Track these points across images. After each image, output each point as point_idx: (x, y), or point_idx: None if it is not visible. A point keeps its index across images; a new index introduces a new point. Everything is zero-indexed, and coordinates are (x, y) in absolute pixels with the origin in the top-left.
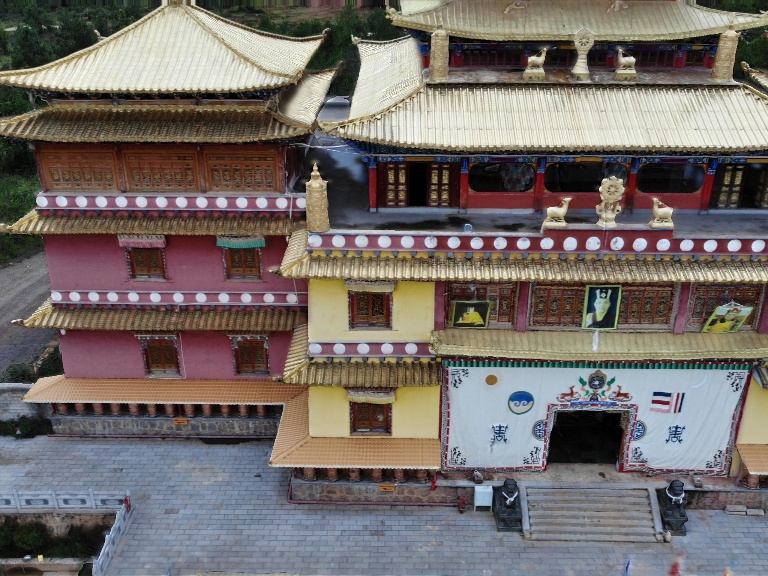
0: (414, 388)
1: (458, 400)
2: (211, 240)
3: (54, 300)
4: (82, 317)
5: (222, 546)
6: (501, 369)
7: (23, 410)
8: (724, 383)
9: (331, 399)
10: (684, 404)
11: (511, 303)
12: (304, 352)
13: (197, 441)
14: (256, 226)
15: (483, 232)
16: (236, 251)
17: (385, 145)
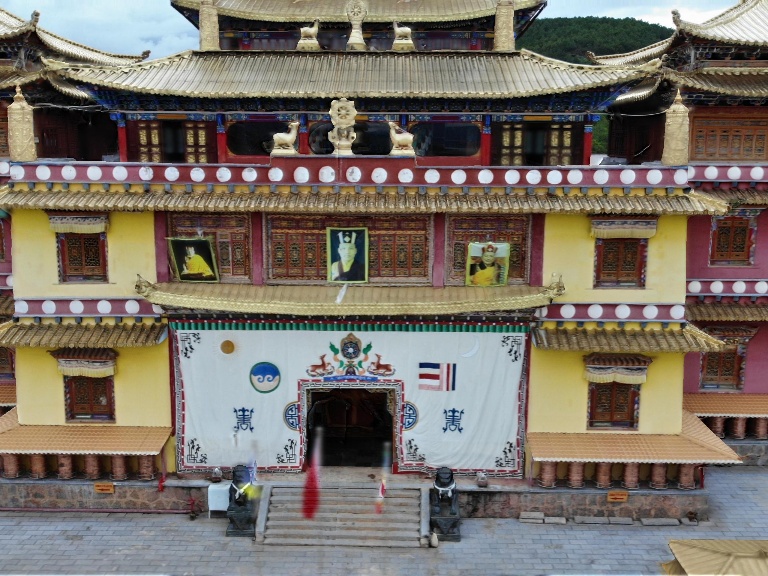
0: (138, 358)
1: (191, 374)
2: None
3: None
4: None
5: None
6: (237, 333)
7: None
8: (500, 350)
9: (42, 374)
10: (457, 379)
11: (246, 251)
12: None
13: None
14: None
15: (205, 163)
16: None
17: (130, 98)
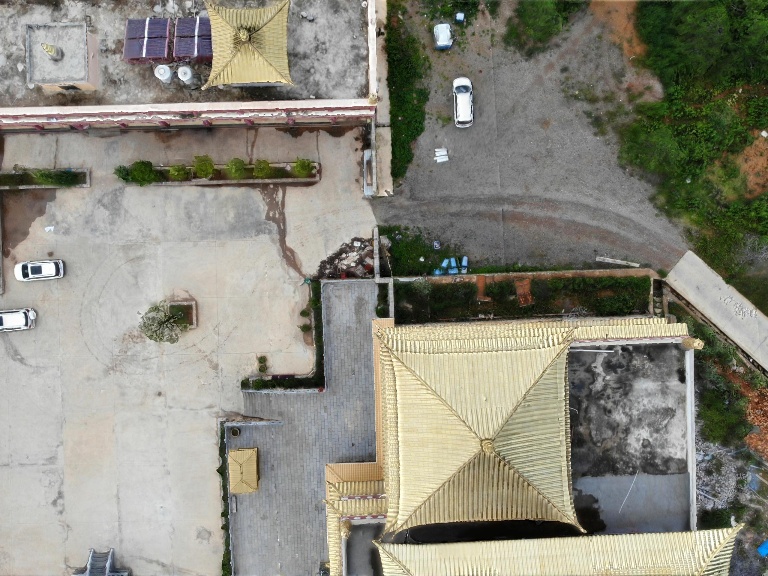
0: None
1: None
2: None
3: None
4: None
5: (305, 439)
6: None
7: None
8: None
9: None
10: None
11: None
12: (353, 492)
13: None
14: None
15: None
16: None
17: None
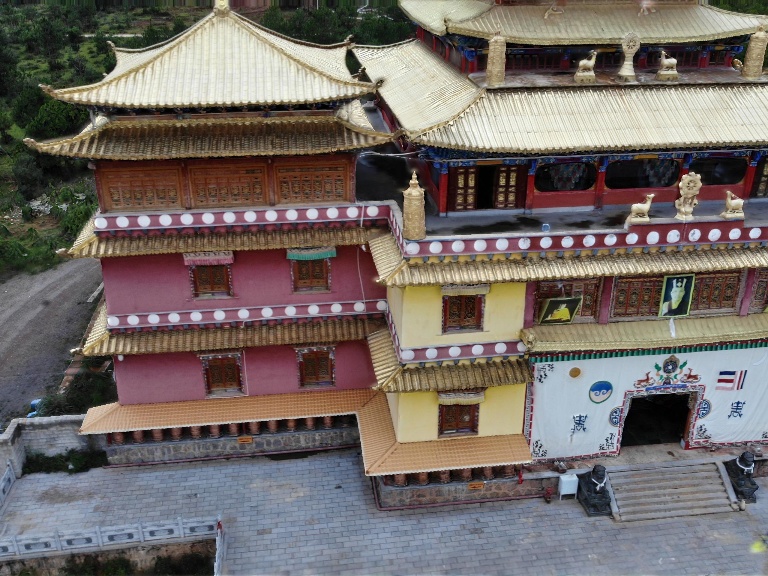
0: (502, 386)
1: (542, 394)
2: (281, 253)
3: (111, 325)
4: (143, 341)
5: (329, 561)
6: (584, 361)
7: (72, 443)
8: None
9: (421, 404)
10: (746, 381)
11: (594, 297)
12: (391, 359)
13: (263, 458)
14: (330, 237)
15: (572, 231)
16: (304, 263)
17: (459, 150)
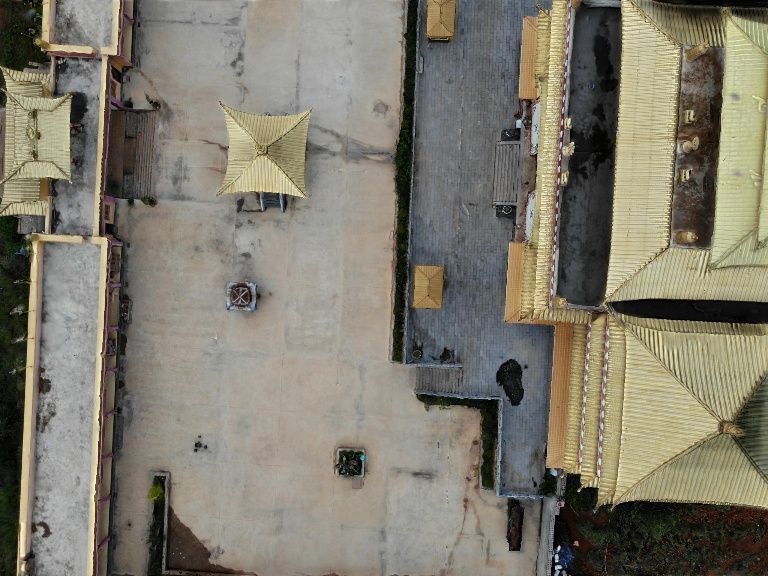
0: None
1: None
2: None
3: None
4: None
5: (498, 5)
6: None
7: None
8: None
9: None
10: None
11: None
12: None
13: None
14: None
15: None
16: None
17: None
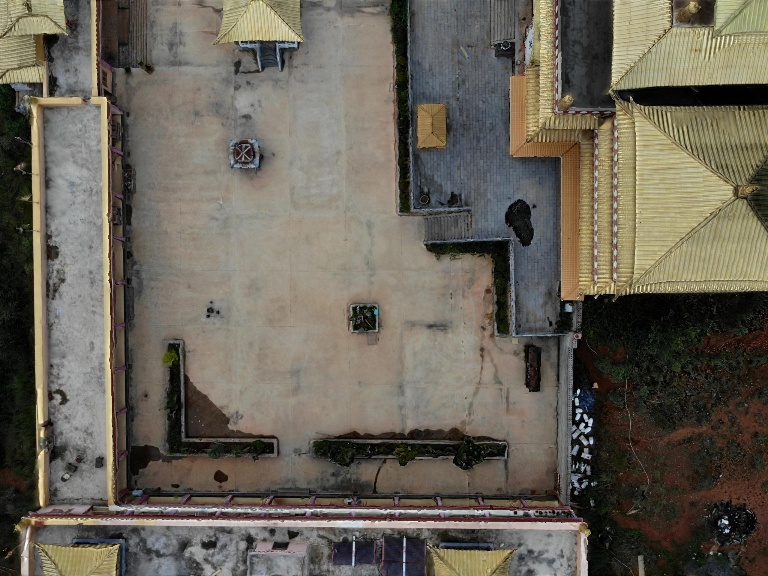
0: None
1: None
2: None
3: None
4: None
5: None
6: None
7: None
8: None
9: None
10: None
11: None
12: None
13: None
14: None
15: None
16: None
17: None
